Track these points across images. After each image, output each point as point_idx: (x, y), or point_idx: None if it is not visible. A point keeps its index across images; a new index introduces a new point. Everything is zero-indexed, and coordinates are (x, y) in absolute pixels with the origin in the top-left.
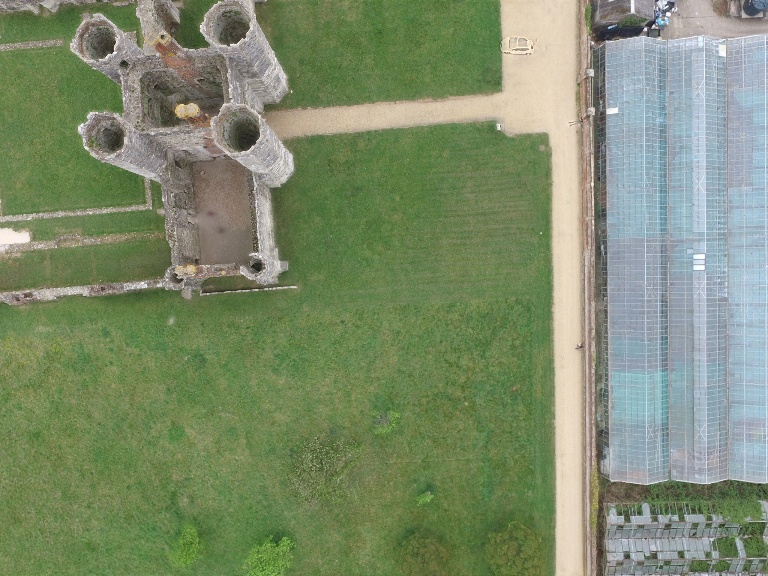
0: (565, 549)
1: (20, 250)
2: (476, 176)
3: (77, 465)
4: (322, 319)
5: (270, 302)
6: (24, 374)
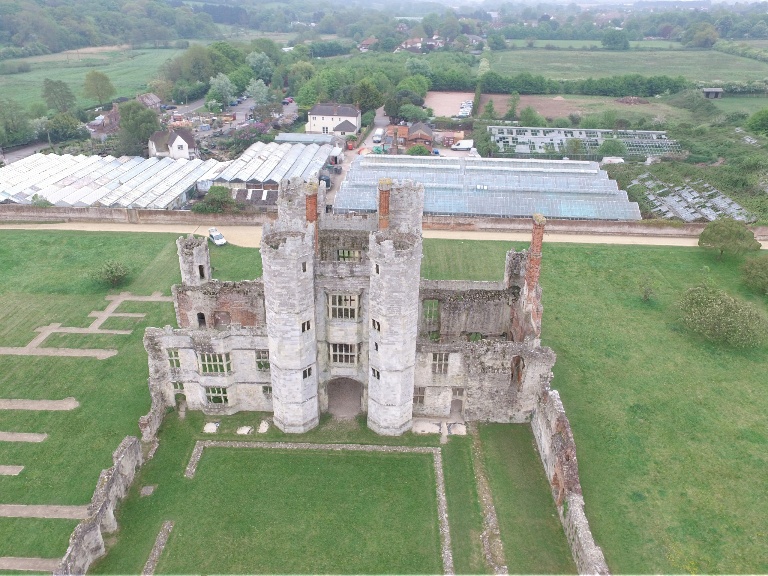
0: None
1: None
2: None
3: None
4: (558, 329)
5: None
6: None
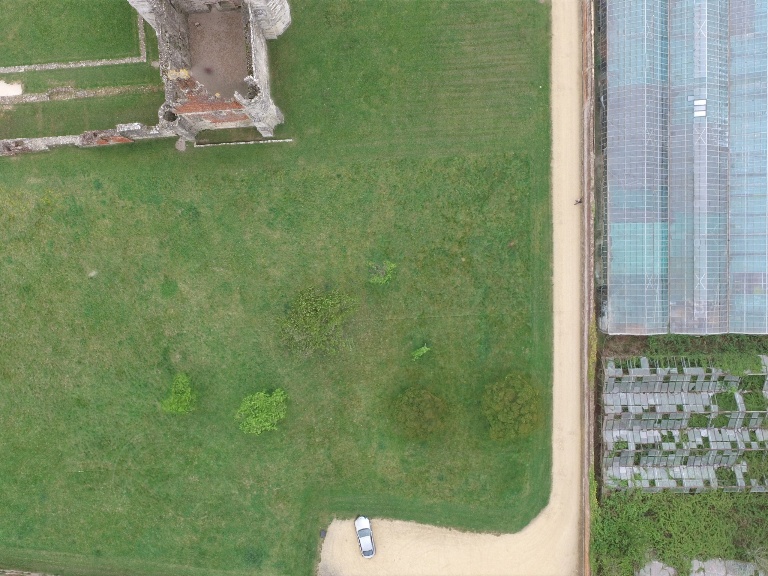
0: (562, 408)
1: (12, 102)
2: (475, 28)
3: (68, 320)
4: (318, 173)
5: (265, 155)
6: (15, 227)
